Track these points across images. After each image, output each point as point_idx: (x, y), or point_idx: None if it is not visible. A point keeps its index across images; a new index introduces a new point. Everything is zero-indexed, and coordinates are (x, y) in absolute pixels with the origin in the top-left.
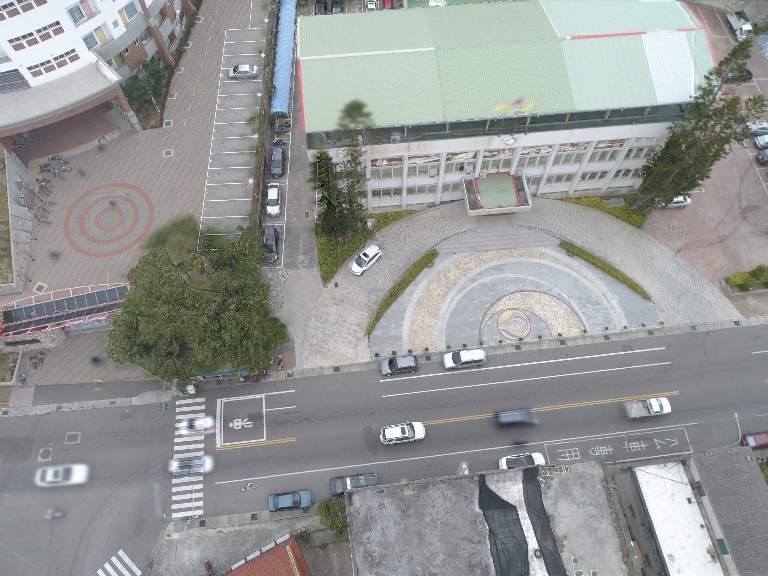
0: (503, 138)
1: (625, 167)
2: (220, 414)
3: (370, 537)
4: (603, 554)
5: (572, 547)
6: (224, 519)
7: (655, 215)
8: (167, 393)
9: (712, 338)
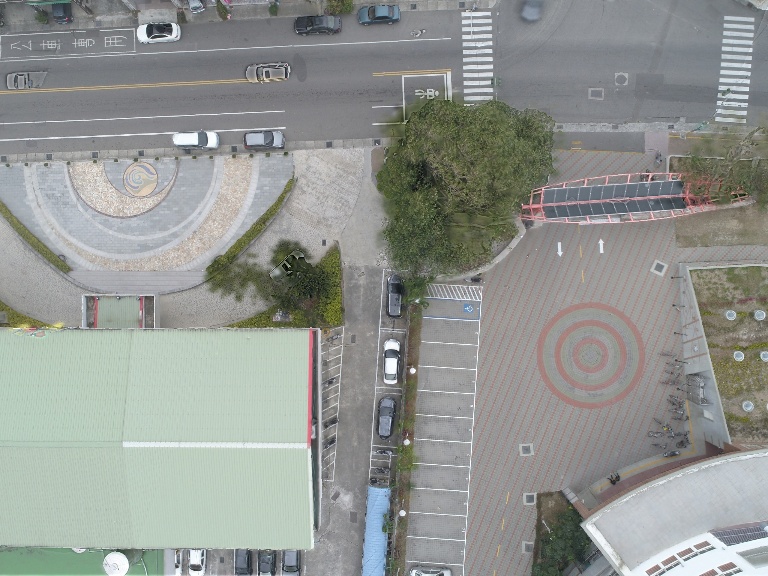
0: None
1: None
2: None
3: None
4: None
5: None
6: (442, 7)
7: None
8: None
9: None
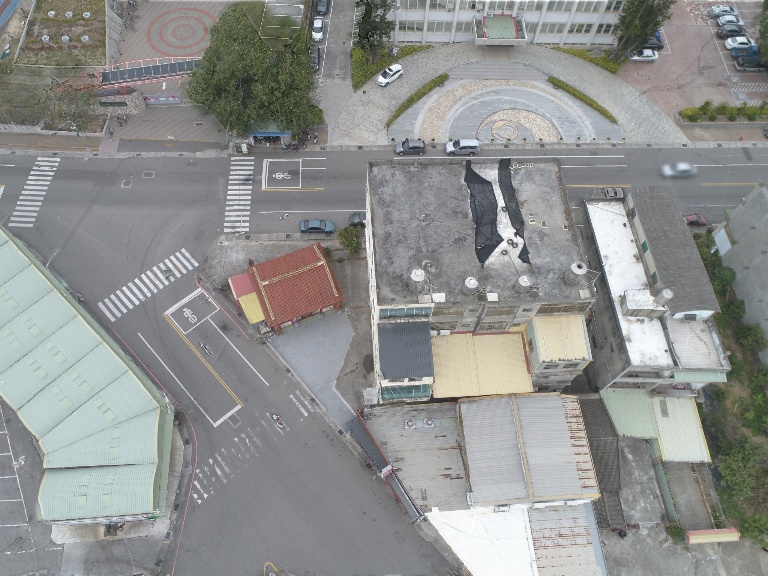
0: None
1: (606, 21)
2: (266, 168)
3: (383, 191)
4: (552, 213)
5: (530, 208)
6: (265, 236)
7: (628, 65)
8: (224, 152)
9: (663, 153)
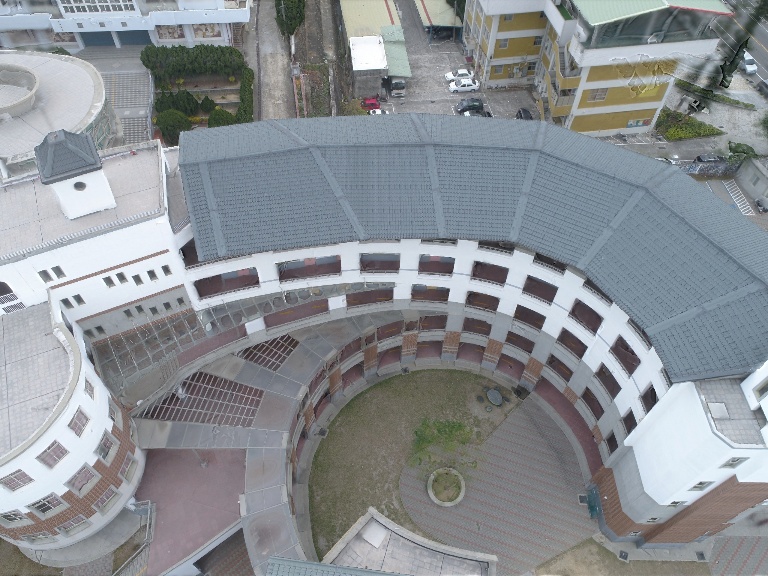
0: None
1: None
2: None
3: None
4: None
5: None
6: None
7: None
8: None
9: None
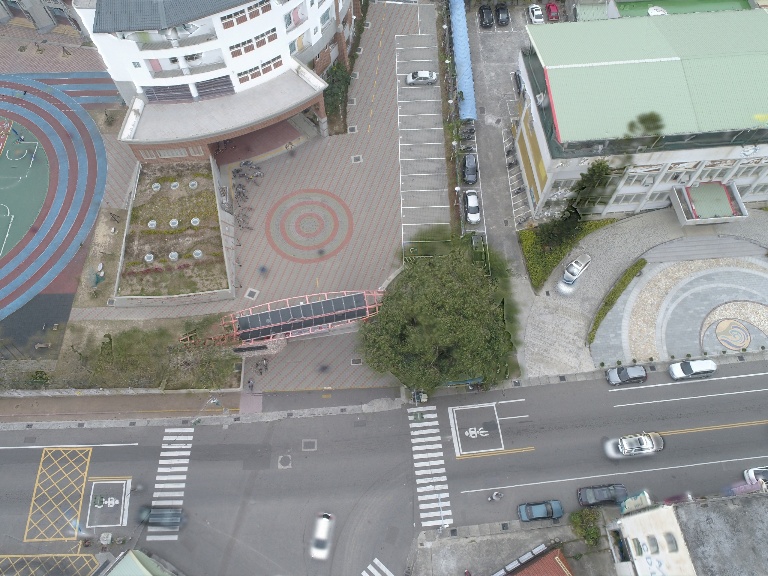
0: (744, 148)
1: None
2: (454, 422)
3: (705, 552)
4: None
5: None
6: (475, 528)
7: None
8: (396, 401)
9: None
